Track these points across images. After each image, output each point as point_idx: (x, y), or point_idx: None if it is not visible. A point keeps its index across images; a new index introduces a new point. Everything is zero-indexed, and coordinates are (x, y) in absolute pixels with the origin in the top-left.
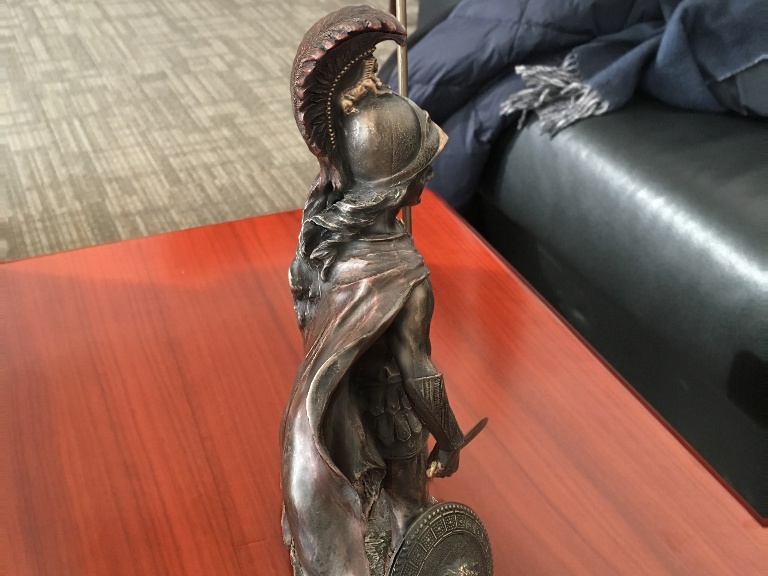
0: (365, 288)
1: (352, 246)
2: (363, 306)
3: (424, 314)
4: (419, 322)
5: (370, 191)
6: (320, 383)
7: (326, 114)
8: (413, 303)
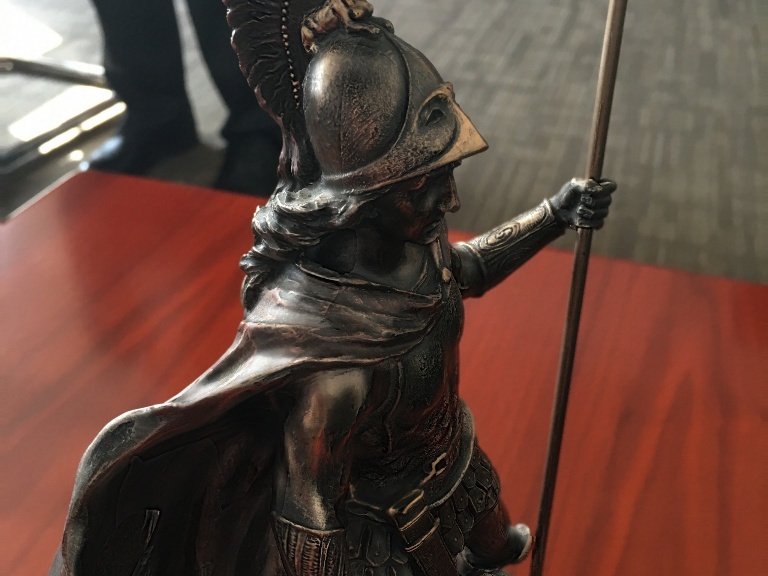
0: (244, 336)
1: (289, 270)
2: (240, 364)
3: (323, 422)
4: (312, 430)
5: (322, 191)
6: (103, 441)
7: (285, 45)
8: (305, 395)
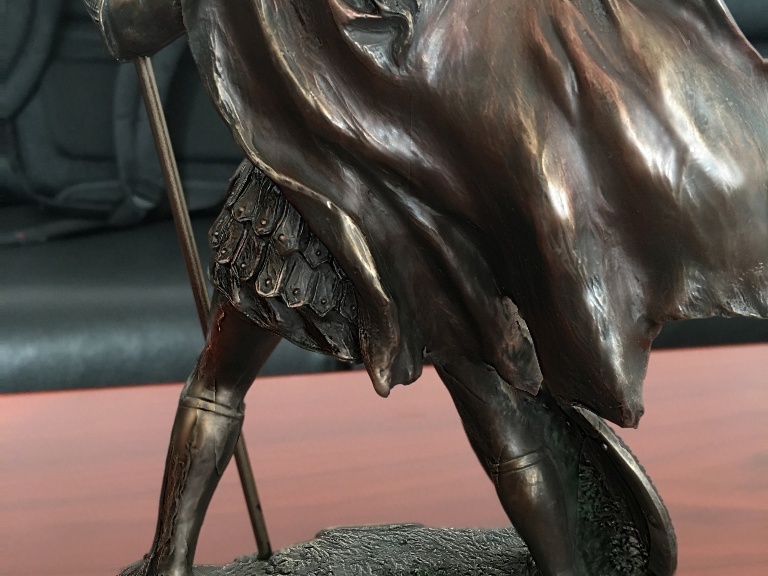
0: None
1: None
2: None
3: None
4: None
5: None
6: None
7: None
8: None
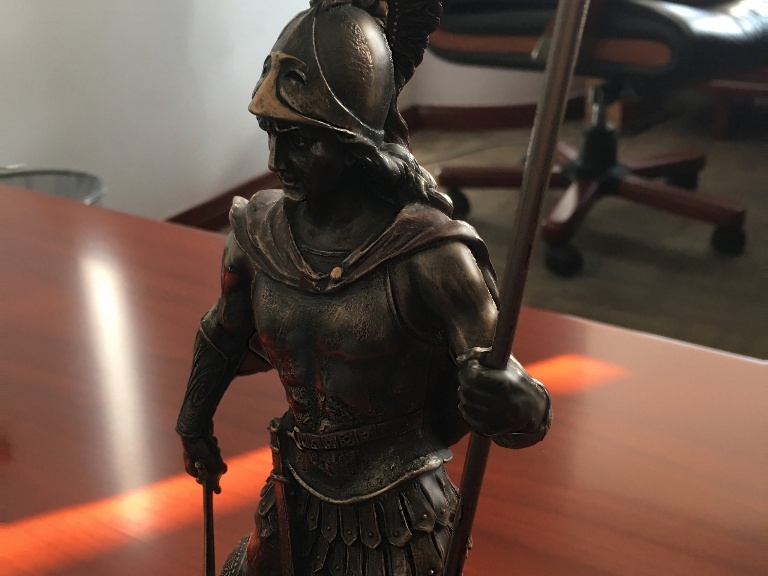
0: None
1: None
2: None
3: None
4: None
5: None
6: None
7: None
8: None
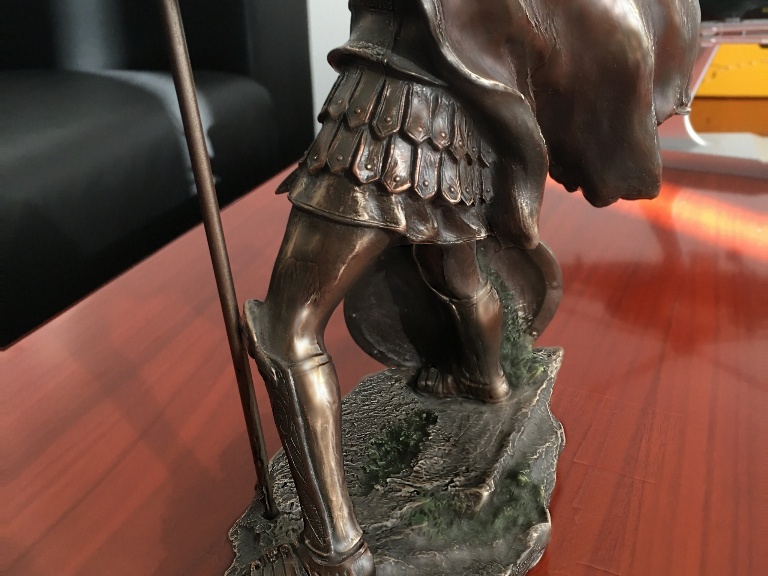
0: None
1: None
2: None
3: None
4: None
5: None
6: None
7: None
8: None
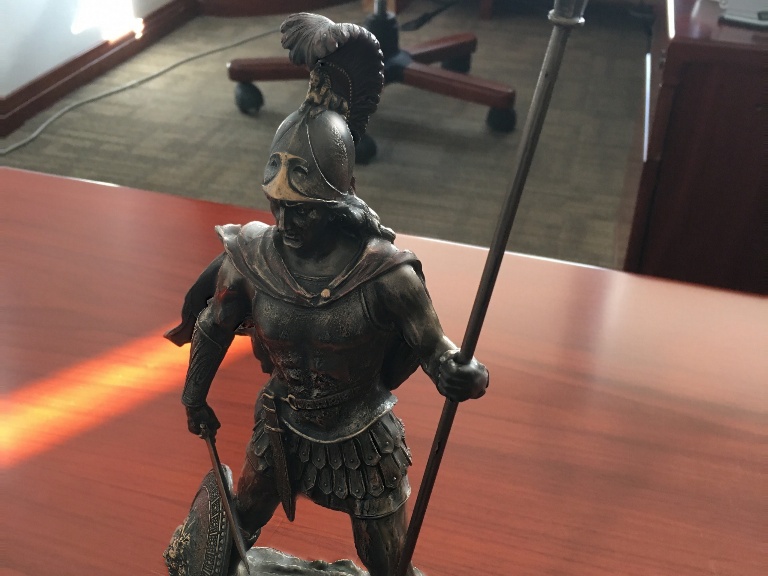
0: None
1: None
2: None
3: None
4: None
5: None
6: None
7: None
8: None
